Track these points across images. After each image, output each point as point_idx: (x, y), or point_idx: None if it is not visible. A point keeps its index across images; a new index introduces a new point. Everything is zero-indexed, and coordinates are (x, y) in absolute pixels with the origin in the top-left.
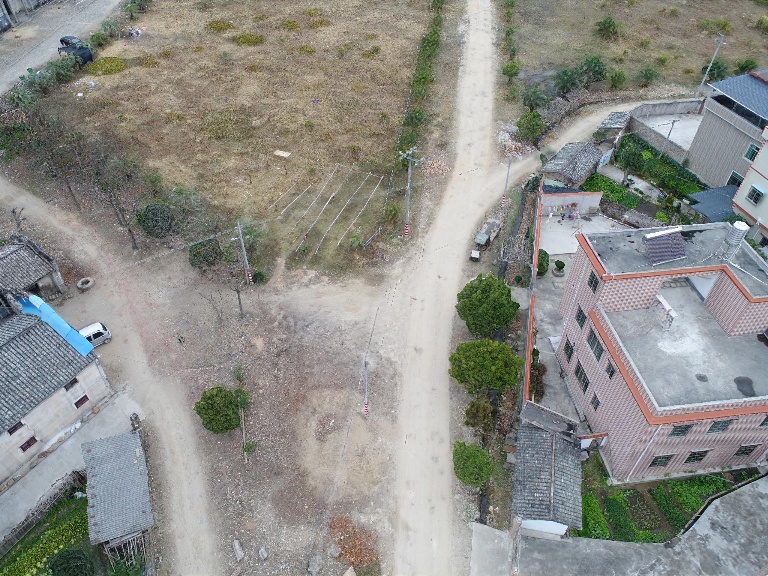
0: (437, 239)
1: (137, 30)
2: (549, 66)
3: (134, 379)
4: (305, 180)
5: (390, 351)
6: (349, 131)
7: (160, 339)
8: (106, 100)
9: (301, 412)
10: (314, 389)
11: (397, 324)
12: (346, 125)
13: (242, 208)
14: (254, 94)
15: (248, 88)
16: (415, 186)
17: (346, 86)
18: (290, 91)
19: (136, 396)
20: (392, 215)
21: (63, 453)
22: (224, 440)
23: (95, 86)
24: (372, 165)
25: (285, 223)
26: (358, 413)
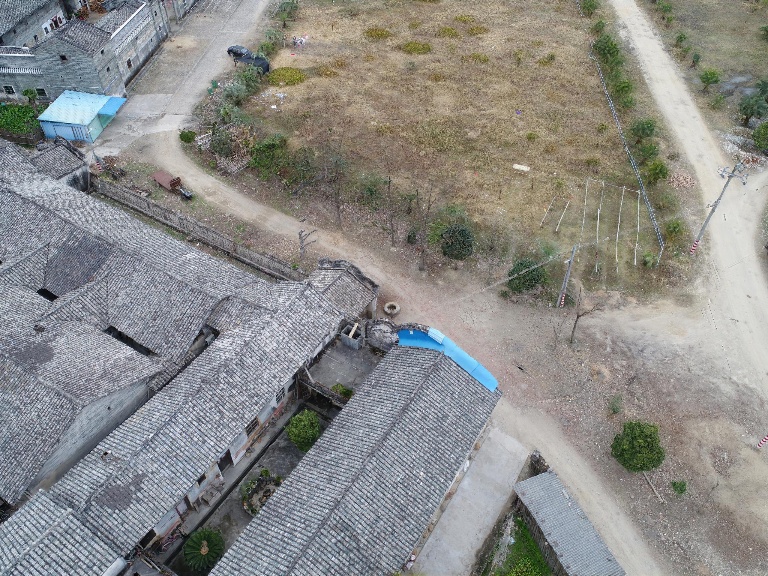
0: (724, 256)
1: (301, 39)
2: (733, 73)
3: (496, 411)
4: (555, 195)
5: (743, 377)
6: (570, 143)
7: (499, 368)
8: (306, 113)
9: (687, 445)
10: (687, 419)
11: (734, 348)
12: (564, 136)
13: (505, 225)
14: (454, 105)
15: (442, 98)
16: (670, 200)
17: (540, 95)
18: (486, 101)
19: (508, 430)
20: (675, 232)
21: (466, 494)
22: (625, 477)
23: (285, 98)
24: (615, 178)
25: (559, 241)
26: (747, 445)
